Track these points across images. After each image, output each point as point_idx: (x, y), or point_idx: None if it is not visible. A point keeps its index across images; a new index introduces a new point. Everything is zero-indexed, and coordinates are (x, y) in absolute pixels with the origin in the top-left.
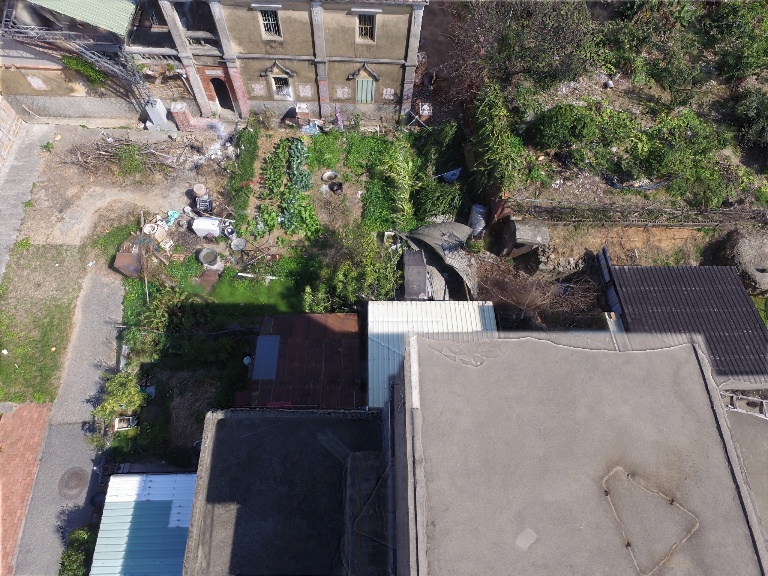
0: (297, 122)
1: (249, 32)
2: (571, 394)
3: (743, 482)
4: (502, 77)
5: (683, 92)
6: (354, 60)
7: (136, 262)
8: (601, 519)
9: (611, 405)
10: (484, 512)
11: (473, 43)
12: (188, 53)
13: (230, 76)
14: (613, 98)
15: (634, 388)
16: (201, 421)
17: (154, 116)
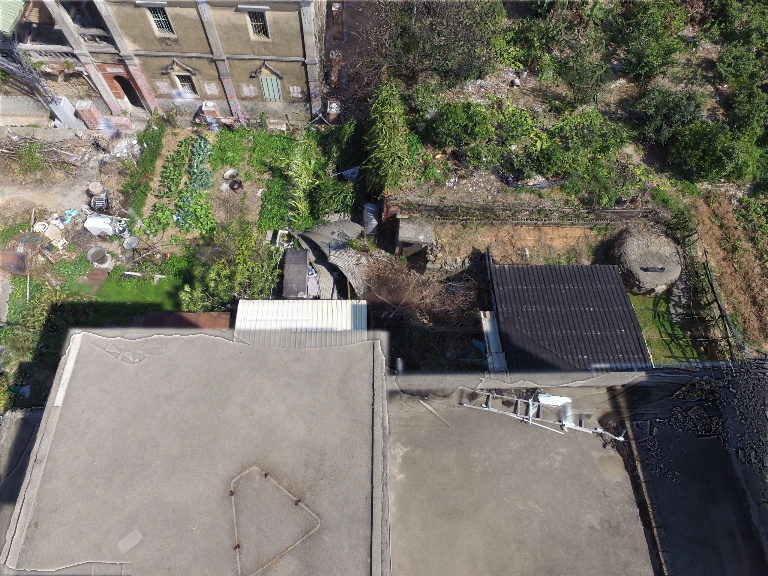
0: (207, 120)
1: (141, 29)
2: (228, 392)
3: (381, 482)
4: (409, 75)
5: (583, 90)
6: (253, 58)
7: (18, 260)
8: (219, 520)
9: (271, 403)
10: (95, 513)
11: (371, 40)
12: (84, 50)
13: (131, 74)
14: (519, 96)
15: (297, 386)
16: None
17: (60, 114)
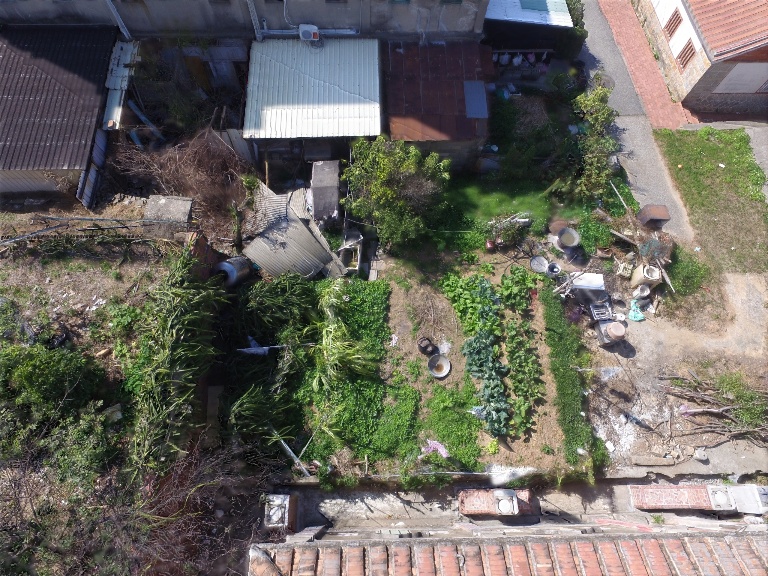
0: None
1: None
2: None
3: None
4: None
5: None
6: None
7: (645, 214)
8: None
9: None
10: None
11: (151, 575)
12: (759, 529)
13: None
14: None
15: None
16: (521, 108)
17: None
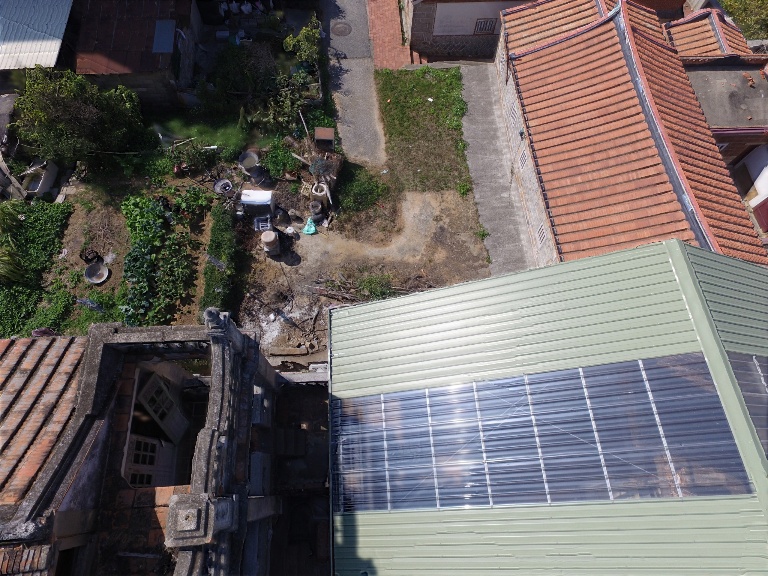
0: None
1: None
2: None
3: None
4: None
5: None
6: None
7: None
8: None
9: None
10: None
11: None
12: None
13: None
14: None
15: None
16: (248, 52)
17: None
